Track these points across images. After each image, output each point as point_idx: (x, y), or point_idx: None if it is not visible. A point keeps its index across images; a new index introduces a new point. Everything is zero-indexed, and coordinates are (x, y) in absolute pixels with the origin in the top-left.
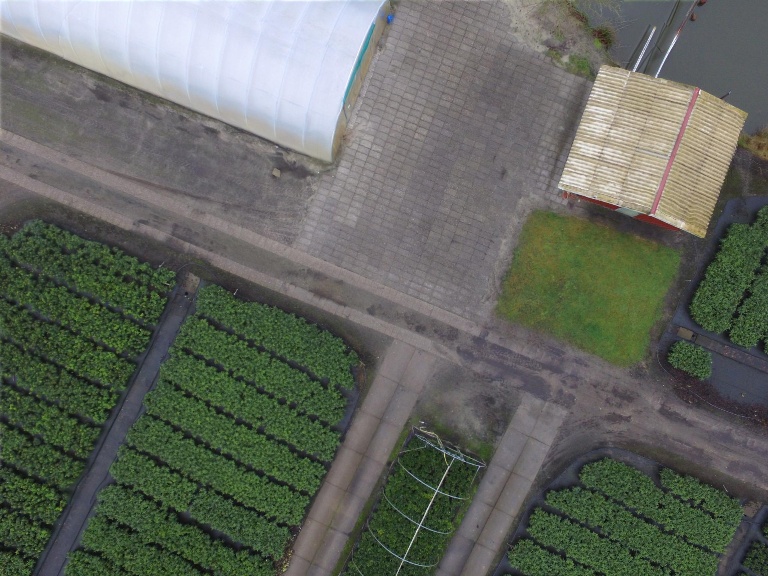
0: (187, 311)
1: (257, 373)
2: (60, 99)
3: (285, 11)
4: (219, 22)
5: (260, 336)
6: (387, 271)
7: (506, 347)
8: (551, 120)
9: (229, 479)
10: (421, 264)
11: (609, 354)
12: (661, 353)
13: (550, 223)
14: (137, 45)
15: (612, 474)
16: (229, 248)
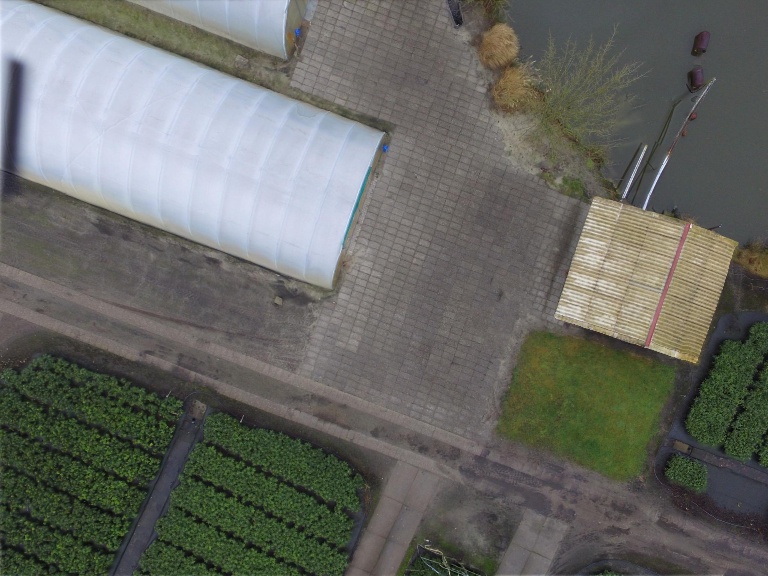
0: (195, 437)
1: (265, 498)
2: (64, 234)
3: (283, 159)
4: (219, 172)
5: (267, 462)
6: (389, 394)
7: (507, 465)
8: (546, 242)
9: None
10: (422, 386)
11: (607, 470)
12: (658, 467)
13: (547, 343)
14: (139, 191)
15: None
16: (234, 376)
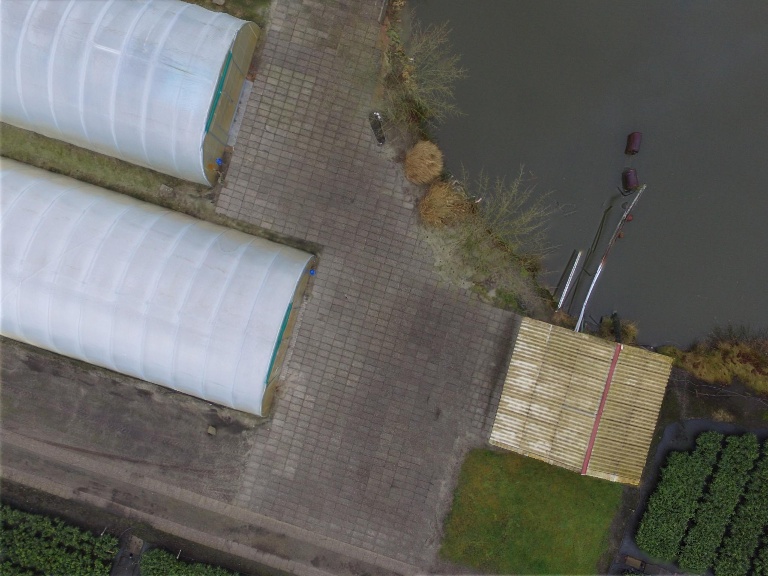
0: (133, 573)
1: None
2: None
3: (202, 301)
4: (137, 318)
5: None
6: (328, 522)
7: None
8: (482, 357)
9: None
10: (362, 512)
11: None
12: None
13: (488, 461)
14: (60, 337)
15: None
16: (170, 510)
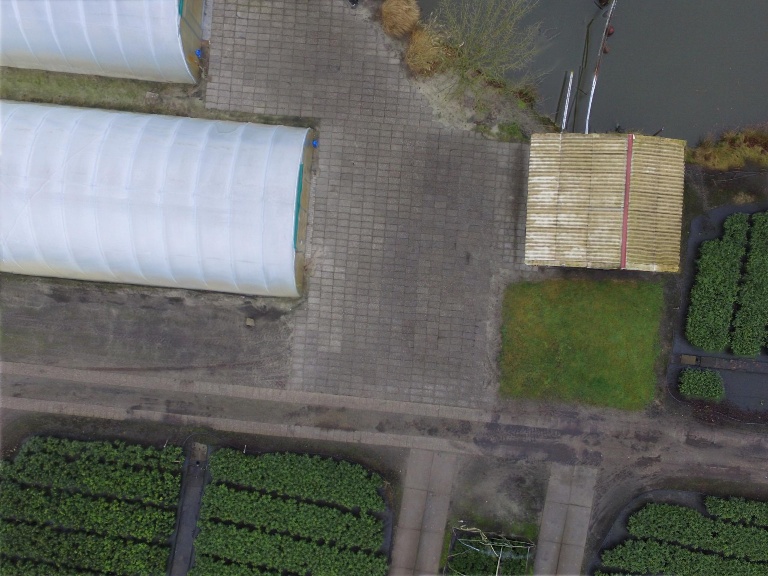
0: (203, 480)
1: (288, 522)
2: (22, 313)
3: (213, 179)
4: (153, 209)
5: (281, 486)
6: (384, 385)
7: (520, 424)
8: (499, 193)
9: None
10: (415, 369)
11: (621, 402)
12: (671, 386)
13: (527, 292)
14: (80, 250)
15: (658, 518)
16: (226, 408)
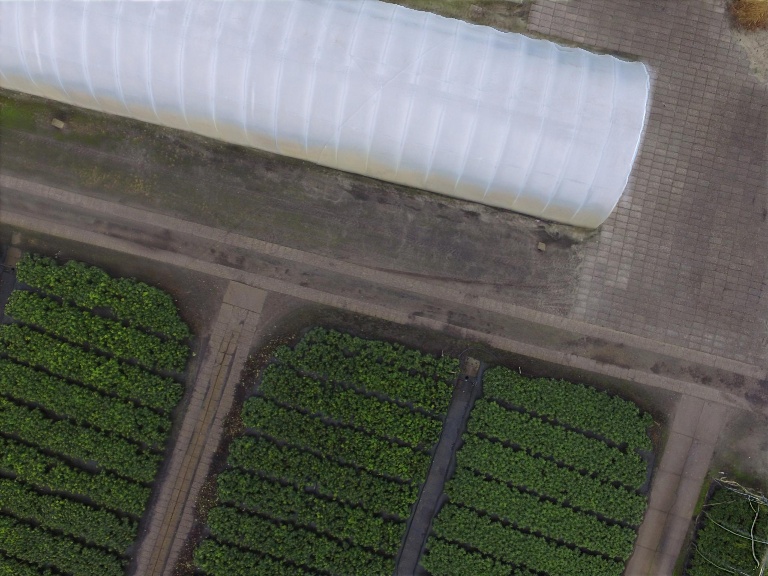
0: (470, 395)
1: (555, 448)
2: (319, 204)
3: (563, 93)
4: (501, 114)
5: (552, 411)
6: (665, 328)
7: None
8: None
9: (543, 556)
10: (697, 316)
11: None
12: None
13: None
14: (413, 146)
15: None
16: (506, 328)
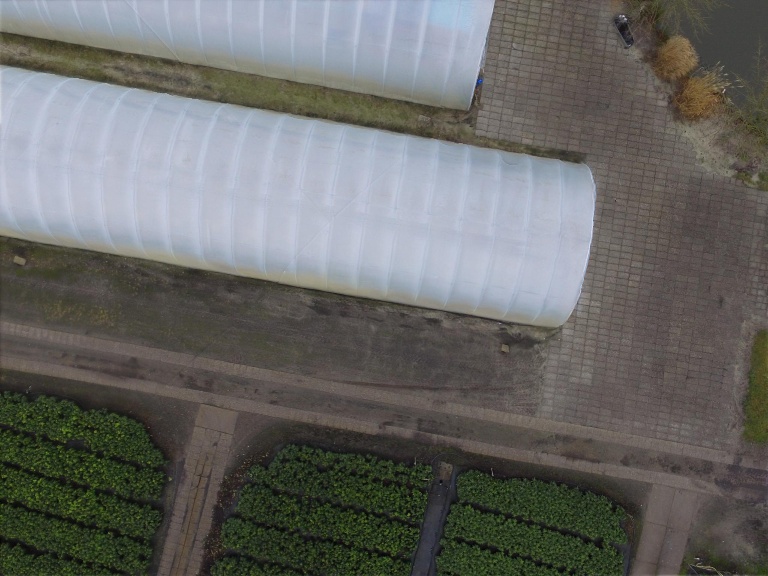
0: (446, 498)
1: (532, 547)
2: (283, 323)
3: (512, 211)
4: (452, 236)
5: (527, 511)
6: (632, 420)
7: (761, 469)
8: (756, 240)
9: None
10: (662, 406)
11: None
12: None
13: None
14: (369, 269)
15: None
16: (476, 431)
